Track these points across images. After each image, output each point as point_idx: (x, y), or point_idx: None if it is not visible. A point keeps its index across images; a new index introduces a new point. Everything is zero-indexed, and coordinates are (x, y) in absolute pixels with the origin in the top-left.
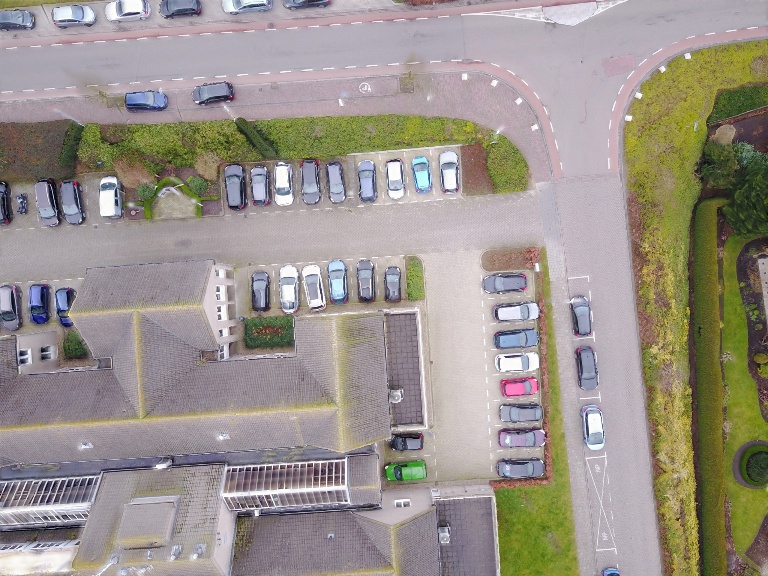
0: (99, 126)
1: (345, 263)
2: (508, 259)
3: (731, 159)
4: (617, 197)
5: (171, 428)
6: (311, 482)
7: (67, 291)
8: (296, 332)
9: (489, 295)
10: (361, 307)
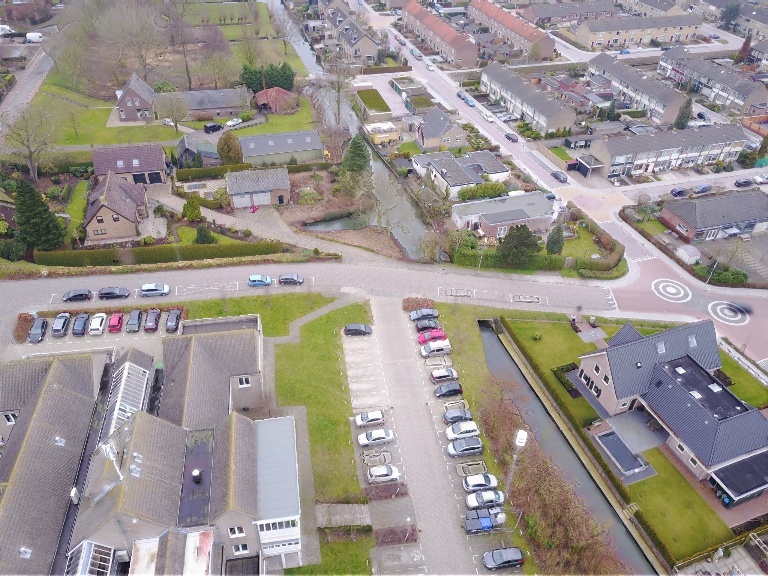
0: None
1: None
2: (20, 328)
3: (6, 241)
4: (5, 284)
5: (31, 470)
6: None
7: None
8: None
9: (45, 340)
10: None
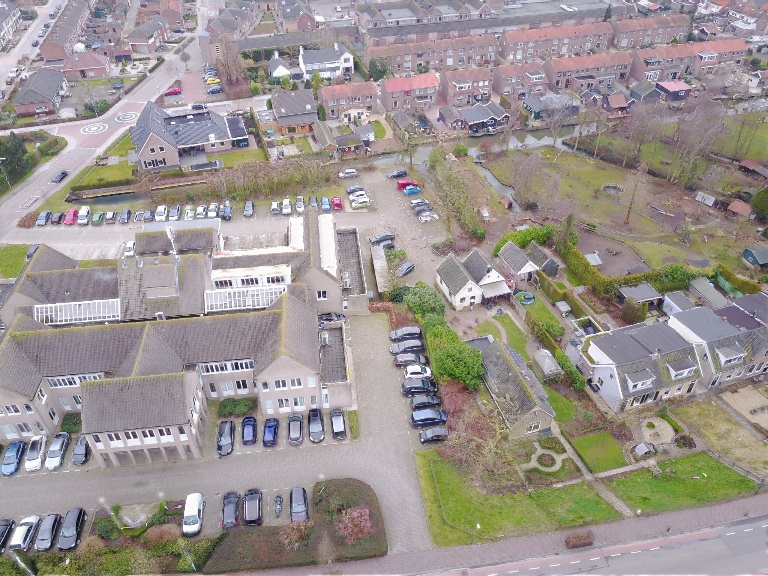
0: (178, 567)
1: (2, 475)
2: None
3: None
4: None
5: None
6: (60, 309)
7: (244, 438)
8: (36, 390)
9: None
10: (5, 443)
